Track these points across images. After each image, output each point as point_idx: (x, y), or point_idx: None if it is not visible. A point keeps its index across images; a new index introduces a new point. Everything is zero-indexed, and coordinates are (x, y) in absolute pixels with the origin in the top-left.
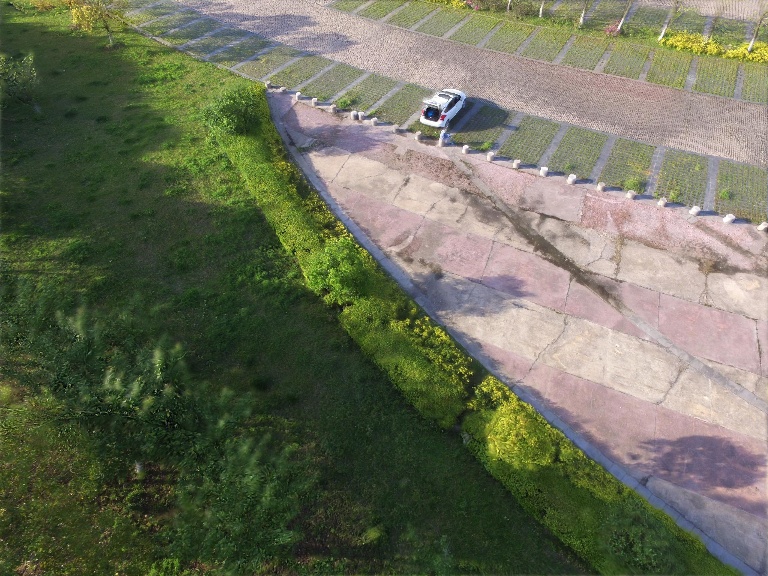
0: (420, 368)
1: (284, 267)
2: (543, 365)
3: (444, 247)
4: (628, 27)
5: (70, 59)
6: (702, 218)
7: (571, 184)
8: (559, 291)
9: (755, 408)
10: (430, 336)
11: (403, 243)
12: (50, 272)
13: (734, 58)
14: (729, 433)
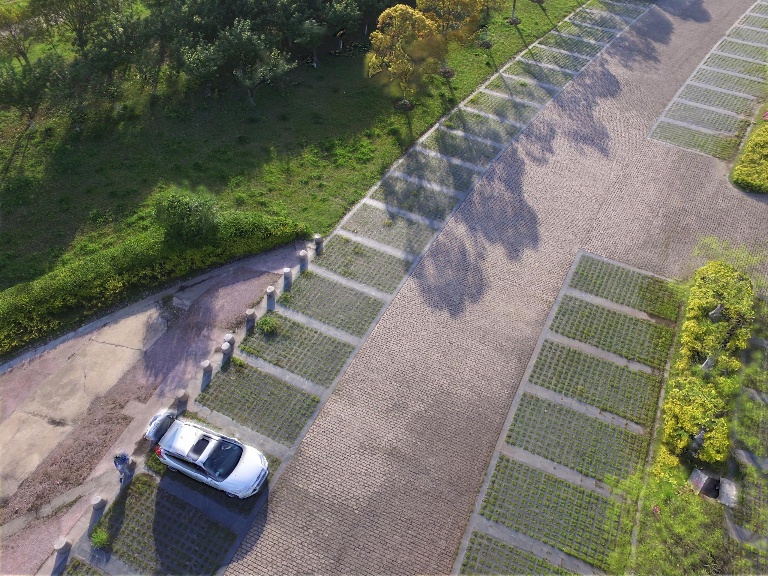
0: None
1: None
2: None
3: None
4: None
5: (368, 89)
6: None
7: None
8: None
9: None
10: None
11: None
12: (2, 177)
13: None
14: None
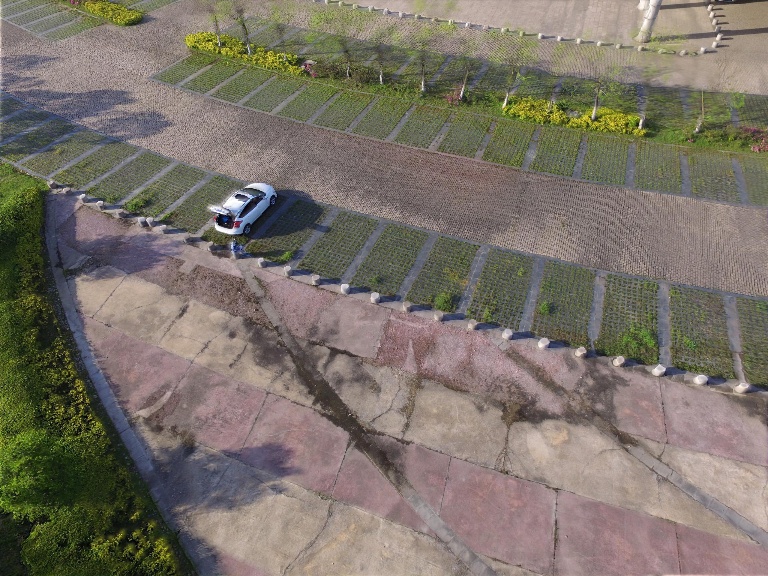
0: None
1: None
2: None
3: (205, 406)
4: (470, 95)
5: None
6: (515, 343)
7: (375, 303)
8: (331, 464)
9: None
10: (142, 561)
11: (156, 404)
12: None
13: (578, 128)
14: None
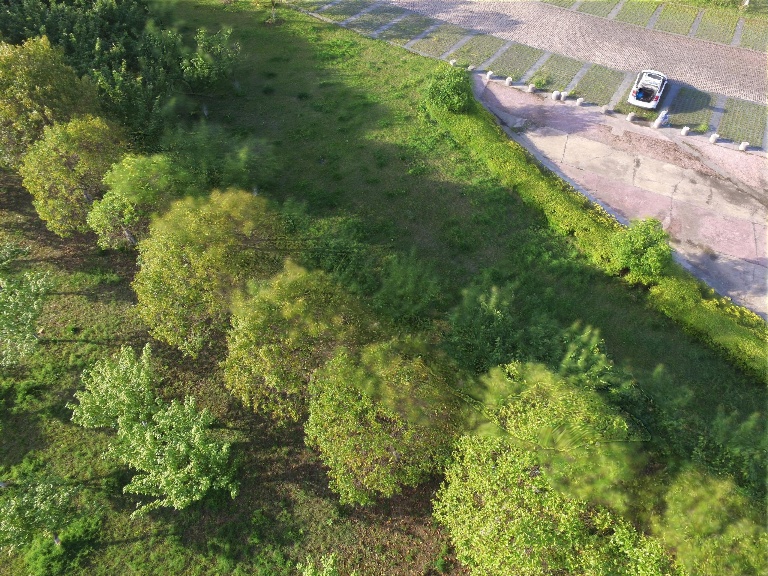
0: (761, 347)
1: (563, 247)
2: None
3: (706, 228)
4: None
5: (237, 34)
6: None
7: None
8: None
9: None
10: (745, 316)
11: (663, 224)
12: (337, 250)
13: None
14: None
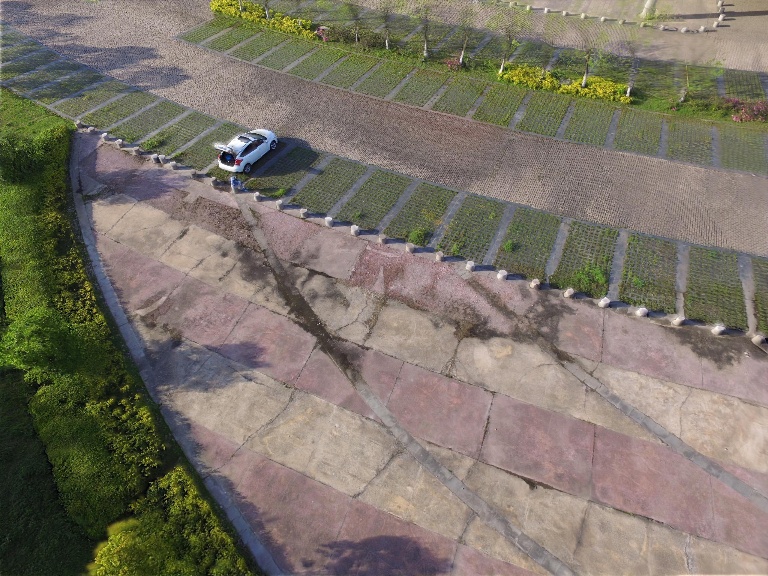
0: (90, 462)
1: None
2: (248, 450)
3: (194, 310)
4: (469, 60)
5: None
6: (477, 274)
7: (354, 235)
8: (297, 361)
9: (458, 500)
10: (127, 420)
11: (152, 306)
12: None
13: (568, 94)
14: (419, 531)
